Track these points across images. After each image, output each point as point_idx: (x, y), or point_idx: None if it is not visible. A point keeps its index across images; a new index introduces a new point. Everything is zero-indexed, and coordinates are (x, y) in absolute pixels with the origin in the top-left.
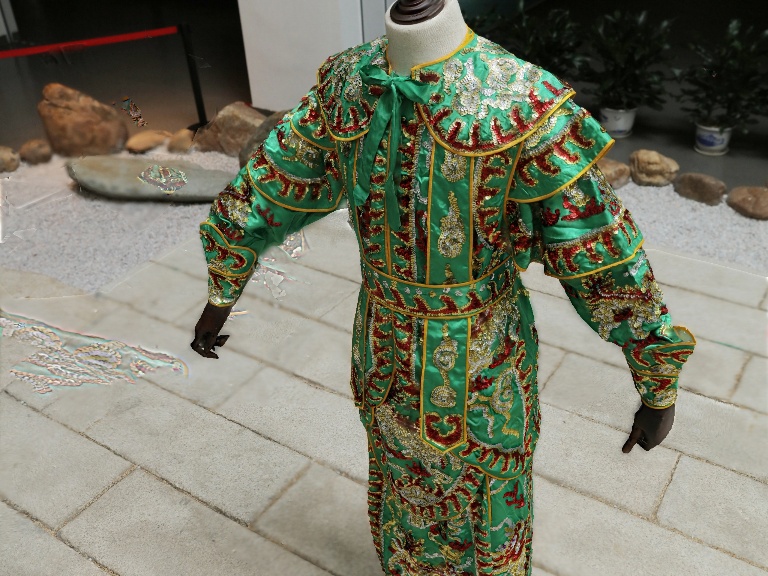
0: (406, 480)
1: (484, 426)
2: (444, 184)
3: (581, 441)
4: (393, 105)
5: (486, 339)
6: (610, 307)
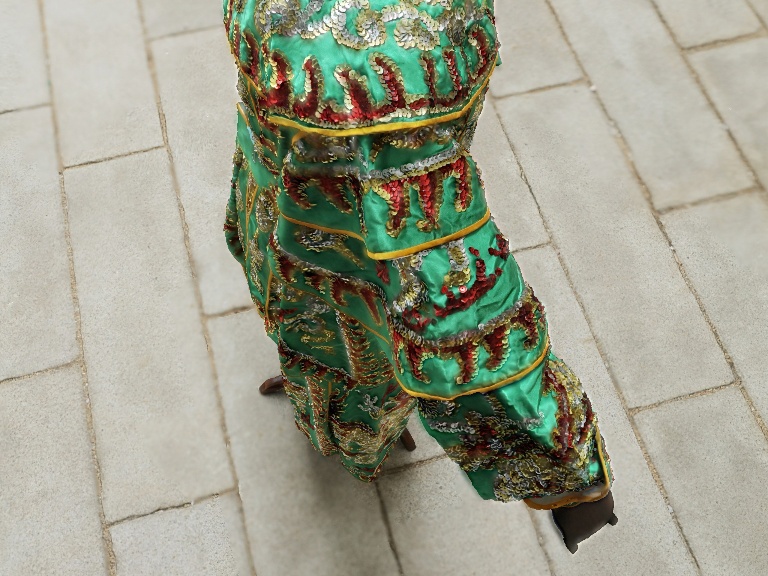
0: None
1: None
2: None
3: (8, 498)
4: None
5: None
6: None
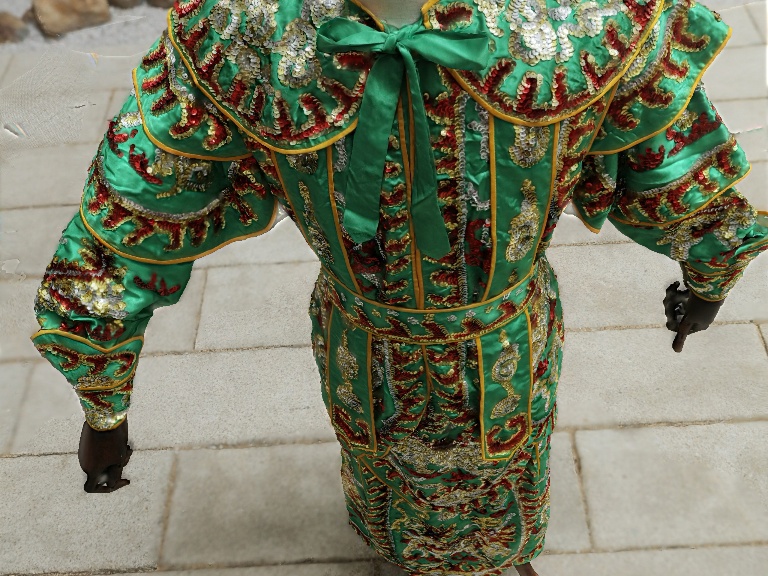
0: (443, 492)
1: (543, 406)
2: (516, 174)
3: None
4: (413, 83)
5: (540, 320)
6: (691, 226)
